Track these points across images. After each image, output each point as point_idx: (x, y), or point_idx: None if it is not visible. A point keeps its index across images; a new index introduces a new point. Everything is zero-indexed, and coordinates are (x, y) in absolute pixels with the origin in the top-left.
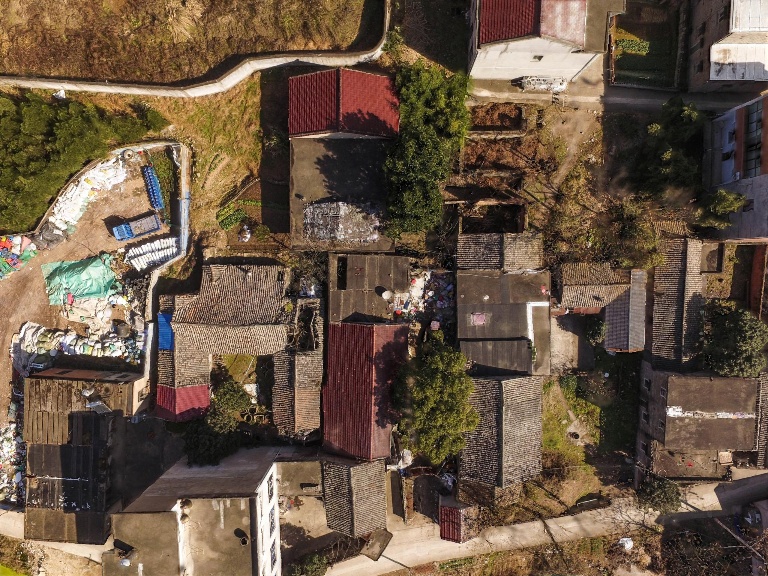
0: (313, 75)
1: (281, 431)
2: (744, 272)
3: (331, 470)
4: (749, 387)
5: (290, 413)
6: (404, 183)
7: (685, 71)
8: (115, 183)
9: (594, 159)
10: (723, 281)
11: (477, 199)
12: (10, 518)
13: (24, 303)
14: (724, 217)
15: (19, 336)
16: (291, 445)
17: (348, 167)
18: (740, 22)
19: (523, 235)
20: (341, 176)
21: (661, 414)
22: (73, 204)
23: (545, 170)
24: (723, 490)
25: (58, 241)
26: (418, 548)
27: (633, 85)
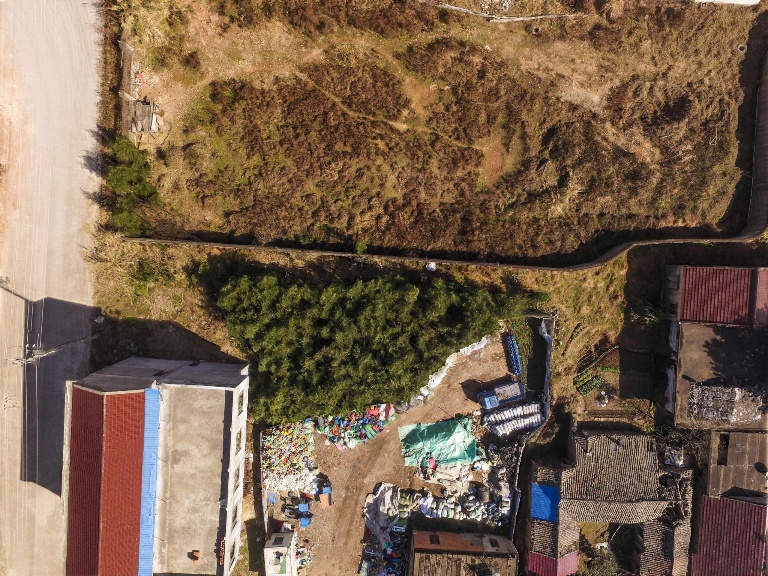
0: (719, 269)
1: None
2: None
3: None
4: None
5: None
6: None
7: None
8: (476, 349)
9: None
10: None
11: None
12: None
13: (379, 464)
14: None
15: (374, 496)
16: None
17: (735, 350)
18: None
19: None
20: (728, 359)
21: None
22: (441, 373)
23: None
24: None
25: (417, 405)
26: None
27: None
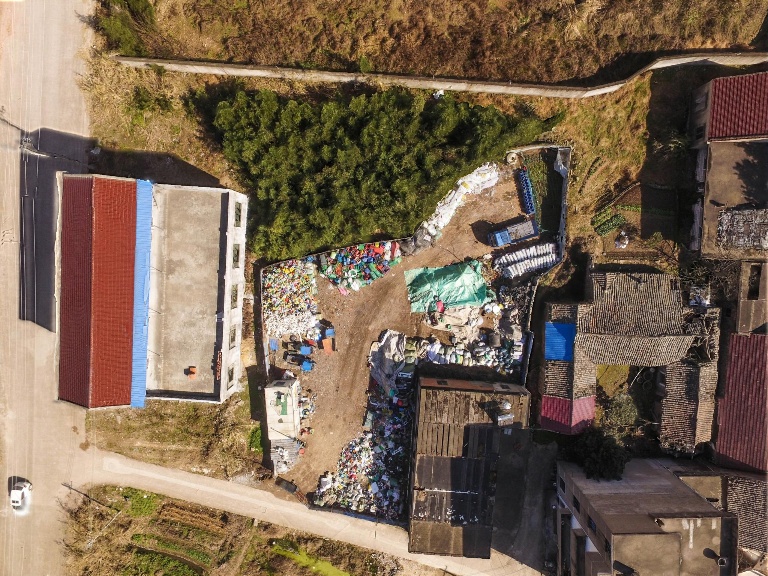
0: (752, 76)
1: (664, 444)
2: None
3: (738, 485)
4: None
5: (687, 426)
6: None
7: None
8: (486, 187)
9: None
10: None
11: None
12: (365, 529)
13: (384, 310)
14: None
15: (379, 344)
16: (663, 457)
17: None
18: None
19: None
20: (761, 182)
21: None
22: (450, 209)
23: None
24: None
25: (424, 247)
26: None
27: None
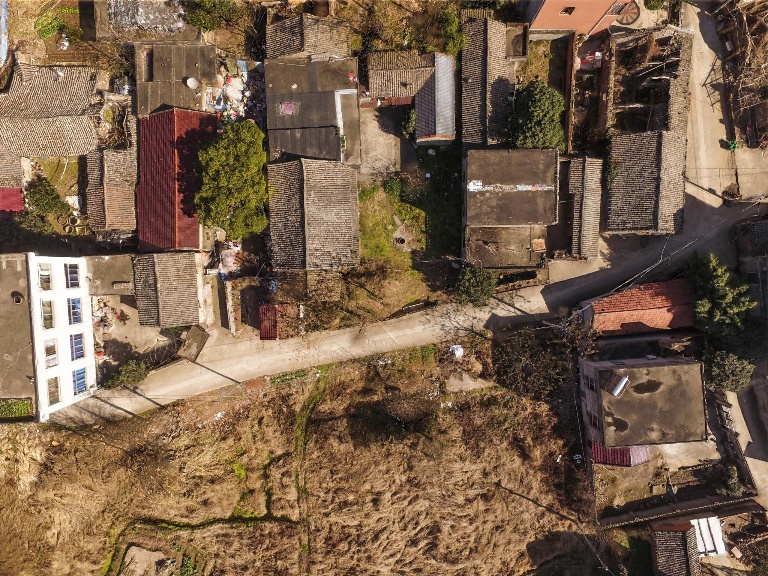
0: None
1: (99, 237)
2: (559, 67)
3: (140, 264)
4: (547, 158)
5: (102, 212)
6: None
7: None
8: None
9: None
10: (539, 77)
11: None
12: None
13: None
14: None
15: None
16: None
17: None
18: None
19: (327, 19)
20: None
21: None
22: None
23: None
24: (549, 292)
25: None
26: (248, 362)
27: None
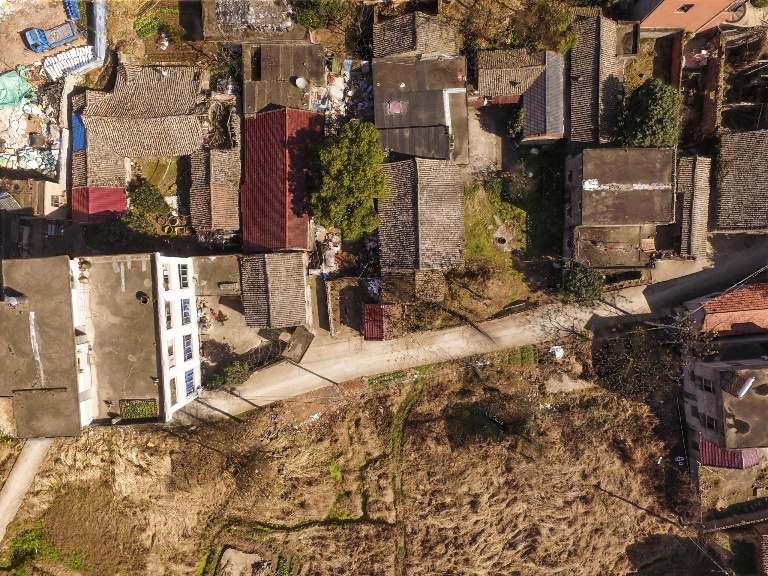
0: None
1: (201, 237)
2: (664, 66)
3: (248, 264)
4: (664, 157)
5: (207, 212)
6: None
7: None
8: None
9: None
10: (643, 75)
11: None
12: None
13: None
14: None
15: None
16: None
17: None
18: None
19: (437, 18)
20: None
21: (580, 195)
22: None
23: None
24: (652, 292)
25: None
26: (346, 363)
27: None
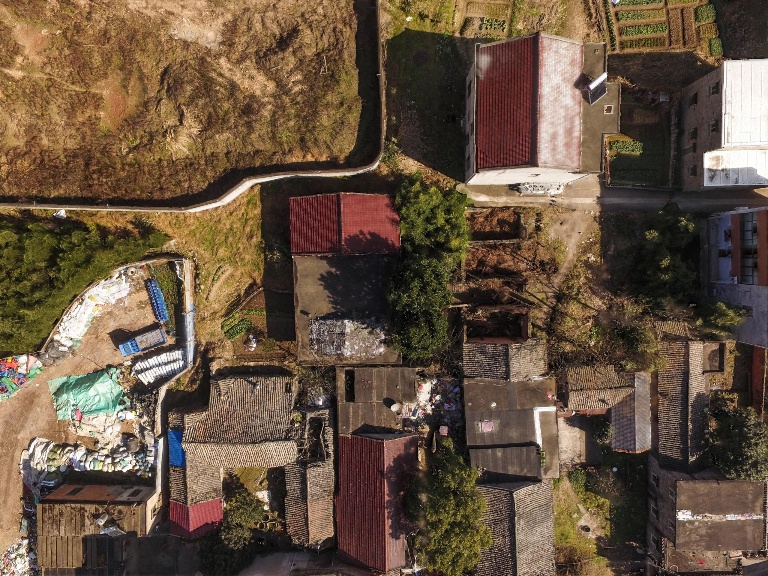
0: (314, 197)
1: (295, 540)
2: (745, 364)
3: None
4: (756, 489)
5: (303, 525)
6: (410, 313)
7: (679, 170)
8: (119, 297)
9: (593, 258)
10: (725, 373)
11: (480, 302)
12: None
13: (32, 419)
14: (724, 326)
15: (28, 452)
16: None
17: (352, 282)
18: (732, 137)
19: (527, 343)
20: (345, 291)
21: (670, 515)
22: (78, 322)
23: (546, 271)
24: None
25: (64, 357)
26: None
27: (629, 187)
